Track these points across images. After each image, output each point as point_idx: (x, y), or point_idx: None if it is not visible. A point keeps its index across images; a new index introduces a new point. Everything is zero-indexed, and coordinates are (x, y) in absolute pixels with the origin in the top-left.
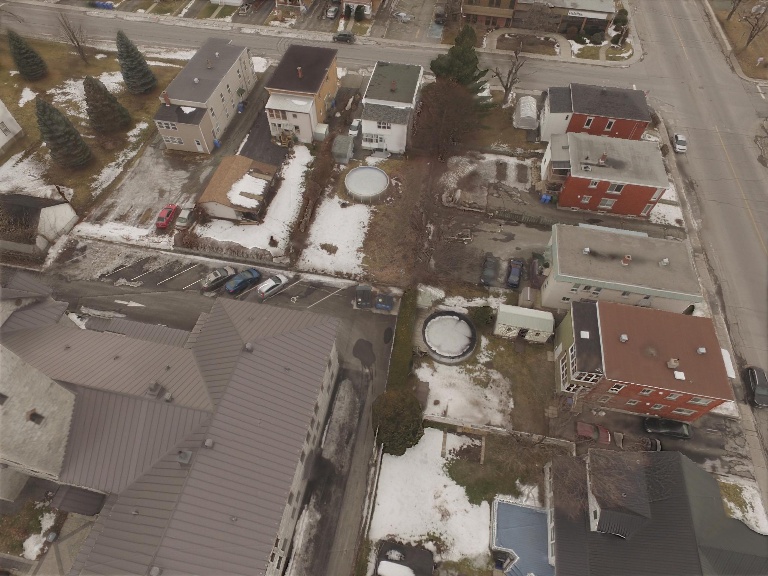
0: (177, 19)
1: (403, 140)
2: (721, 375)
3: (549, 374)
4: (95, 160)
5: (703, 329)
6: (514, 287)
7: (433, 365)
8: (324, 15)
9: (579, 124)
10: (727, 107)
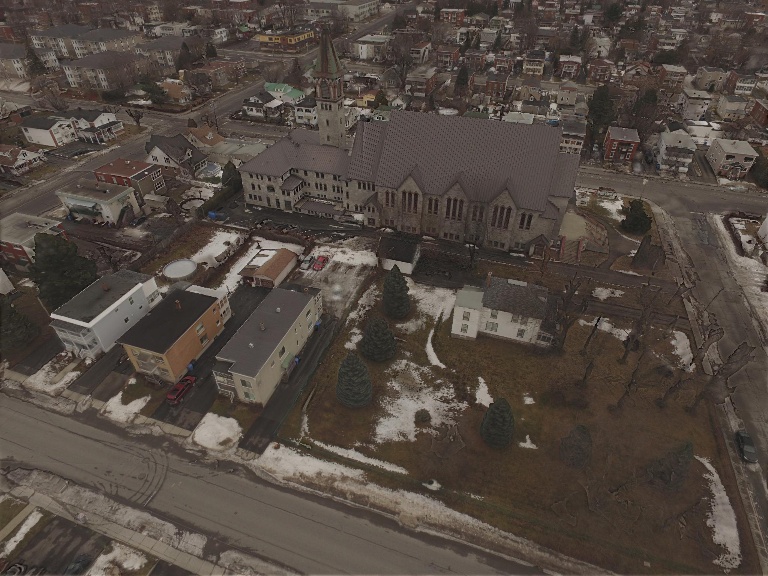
0: None
1: None
2: None
3: None
4: None
5: None
6: None
7: None
8: None
9: None
10: None
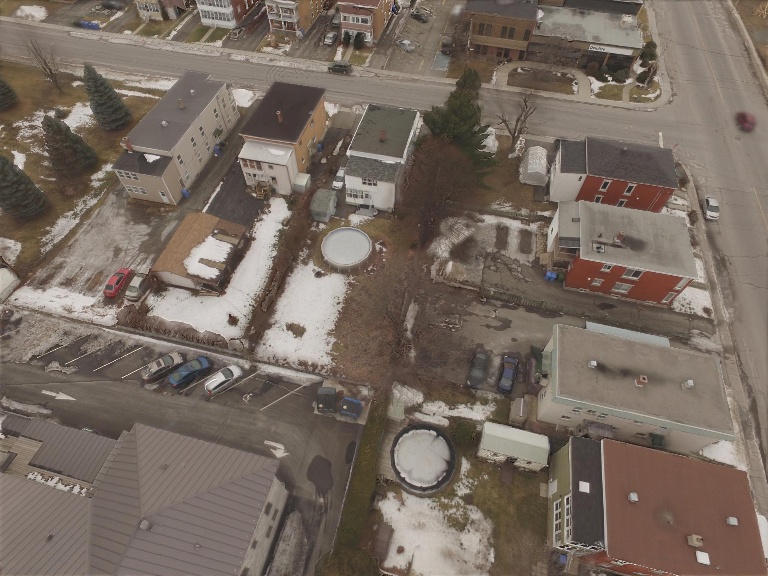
0: (164, 42)
1: (391, 198)
2: (757, 559)
3: (540, 515)
4: (51, 208)
5: (735, 487)
6: (506, 392)
7: (401, 496)
8: (321, 41)
9: (594, 186)
10: (767, 163)
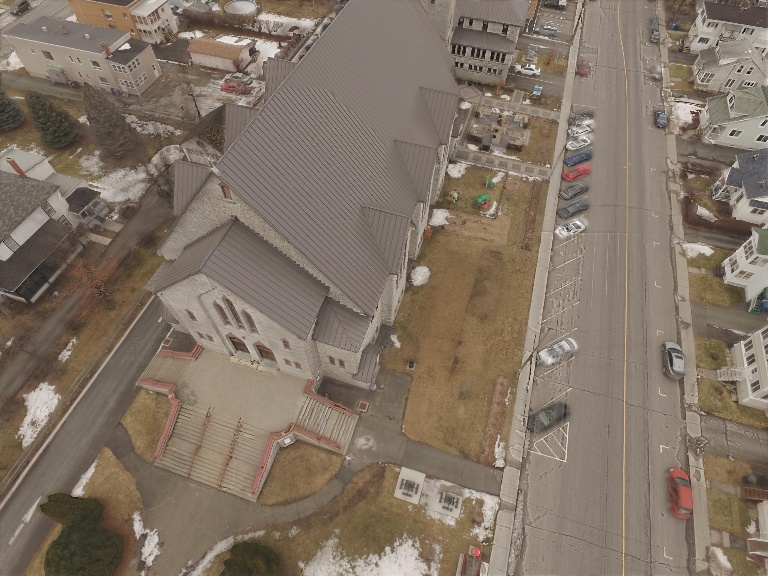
0: None
1: None
2: None
3: None
4: None
5: None
6: None
7: None
8: None
9: None
10: None
